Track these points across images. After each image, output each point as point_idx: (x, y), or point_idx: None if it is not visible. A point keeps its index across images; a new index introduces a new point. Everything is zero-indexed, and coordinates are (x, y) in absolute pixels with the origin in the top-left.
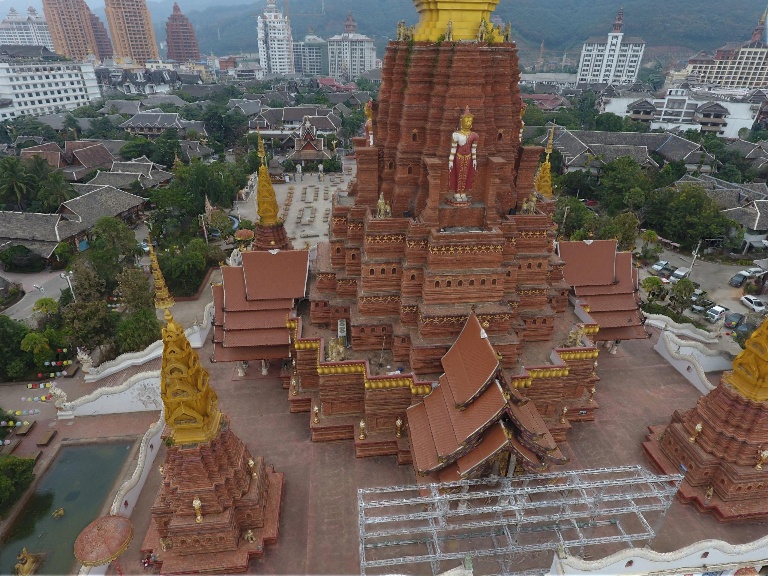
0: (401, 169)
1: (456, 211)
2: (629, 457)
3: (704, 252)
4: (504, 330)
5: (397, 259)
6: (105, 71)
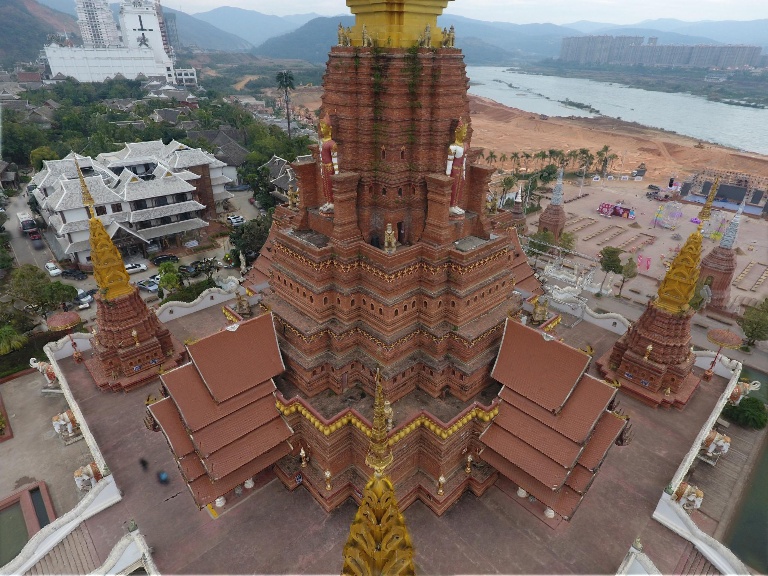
0: None
1: None
2: None
3: None
4: None
5: None
6: None
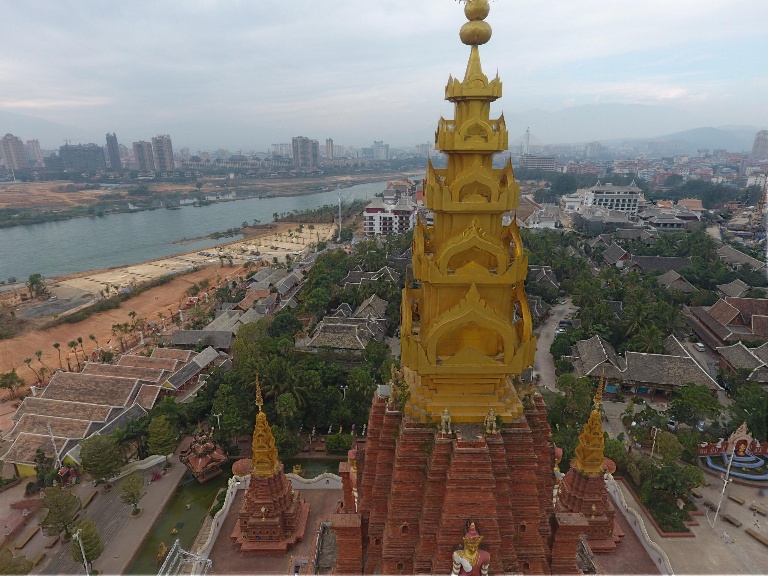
0: None
1: None
2: None
3: None
4: None
5: None
6: None
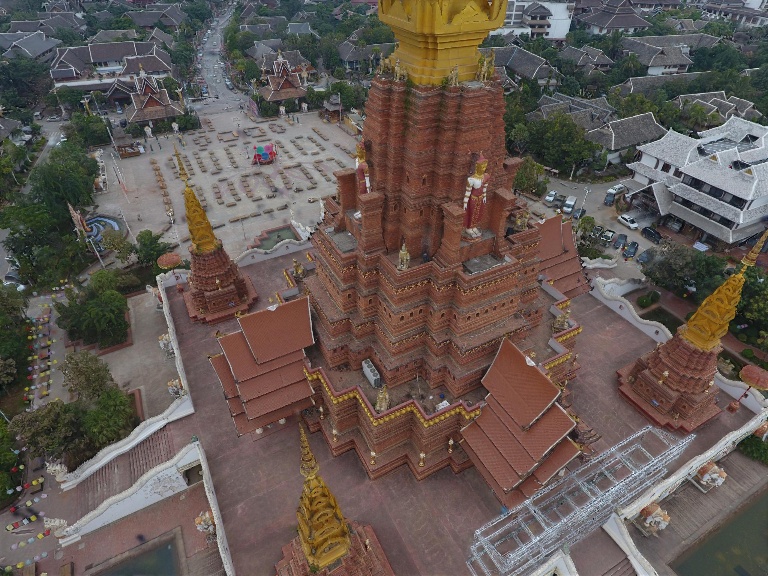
0: (413, 214)
1: (472, 246)
2: (612, 402)
3: (577, 174)
4: (521, 338)
5: (423, 301)
6: None
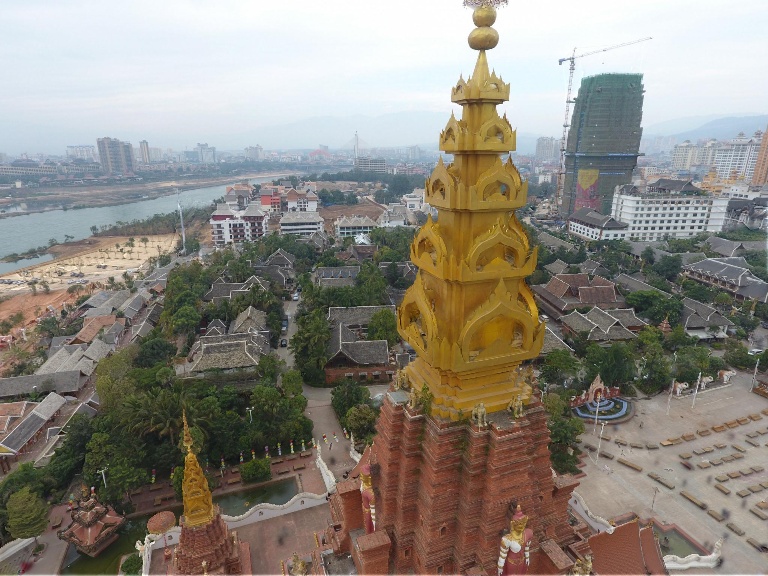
0: None
1: None
2: None
3: None
4: None
5: None
6: (764, 200)
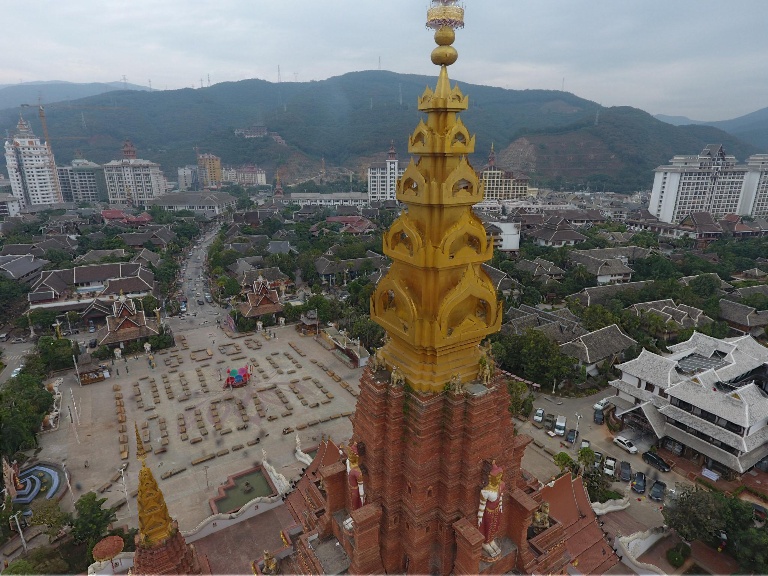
0: (418, 532)
1: (492, 567)
2: None
3: (559, 387)
4: None
5: None
6: None
